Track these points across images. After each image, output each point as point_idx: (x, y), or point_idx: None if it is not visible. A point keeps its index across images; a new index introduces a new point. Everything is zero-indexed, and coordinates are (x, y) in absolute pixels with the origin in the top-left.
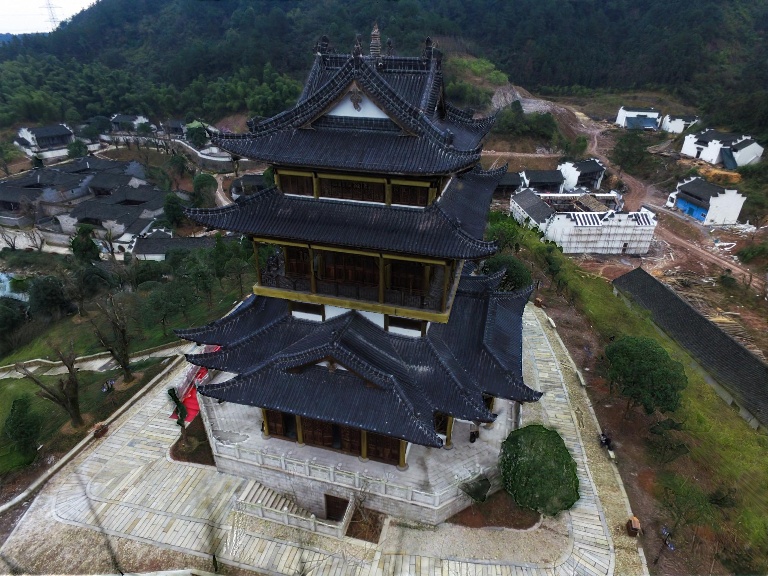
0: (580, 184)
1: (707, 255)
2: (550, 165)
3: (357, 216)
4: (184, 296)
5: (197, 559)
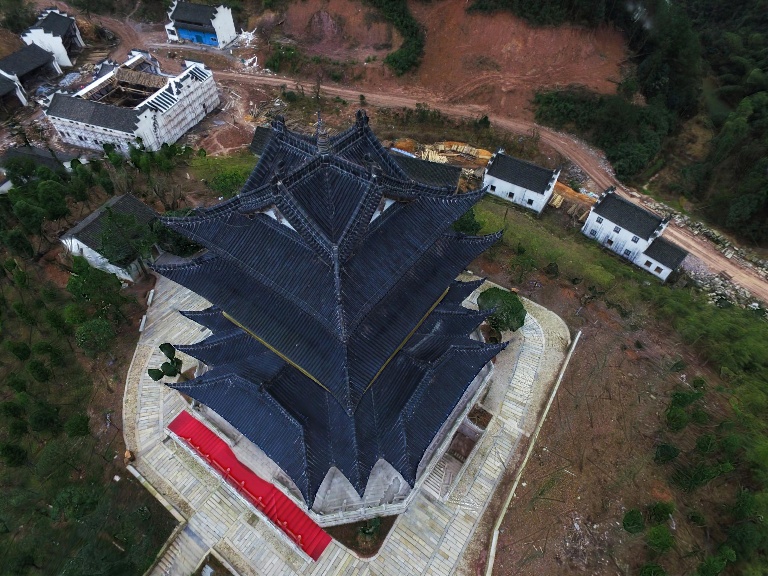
0: (68, 51)
1: (251, 78)
2: (1, 38)
3: (405, 284)
4: (25, 557)
5: (477, 532)
